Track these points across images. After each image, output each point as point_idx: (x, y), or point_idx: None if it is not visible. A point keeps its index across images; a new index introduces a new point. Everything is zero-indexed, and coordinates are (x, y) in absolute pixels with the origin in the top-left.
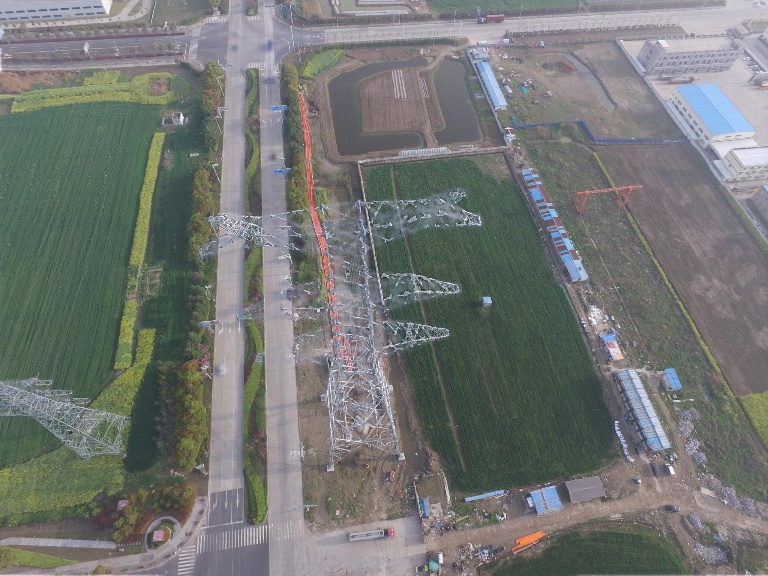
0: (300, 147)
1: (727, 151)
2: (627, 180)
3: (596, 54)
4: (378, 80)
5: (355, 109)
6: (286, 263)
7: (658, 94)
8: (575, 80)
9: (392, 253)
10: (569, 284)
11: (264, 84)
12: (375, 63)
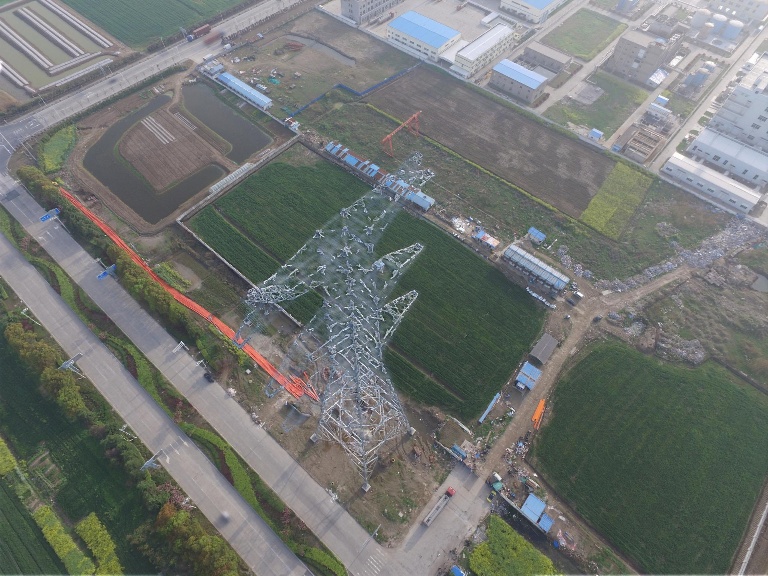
0: (105, 240)
1: (454, 56)
2: (405, 113)
3: (309, 25)
4: (134, 136)
5: (132, 175)
6: (181, 353)
7: (378, 36)
8: (309, 54)
9: None
10: (425, 214)
11: (8, 201)
12: (117, 122)
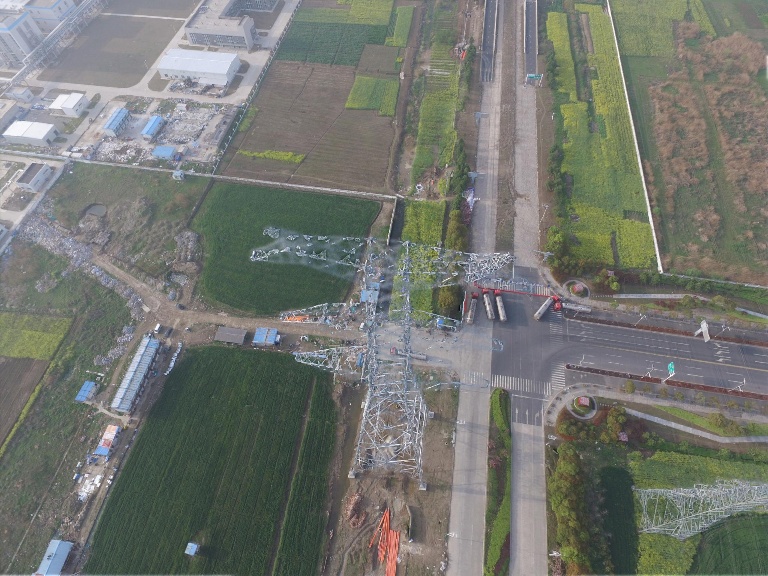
0: None
1: None
2: None
3: None
4: None
5: None
6: None
7: None
8: None
9: None
10: (80, 542)
11: None
12: None
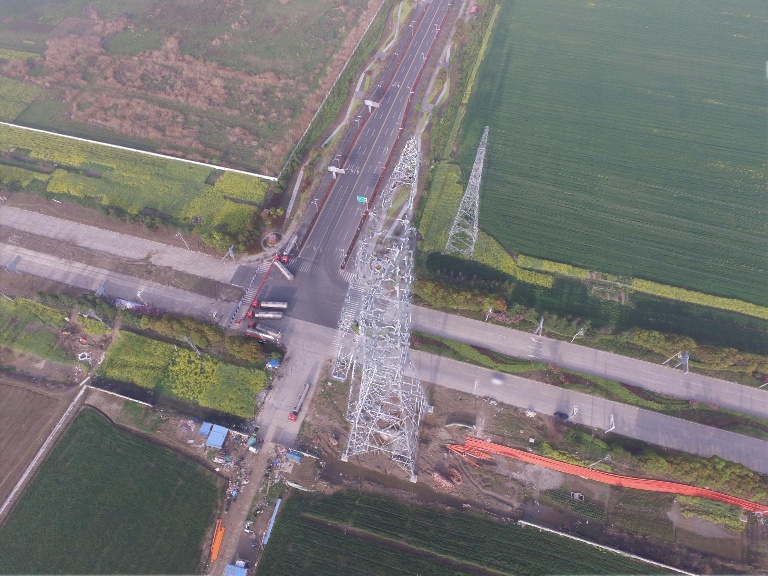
0: None
1: None
2: None
3: None
4: None
5: None
6: None
7: None
8: None
9: (599, 575)
10: None
11: None
12: None
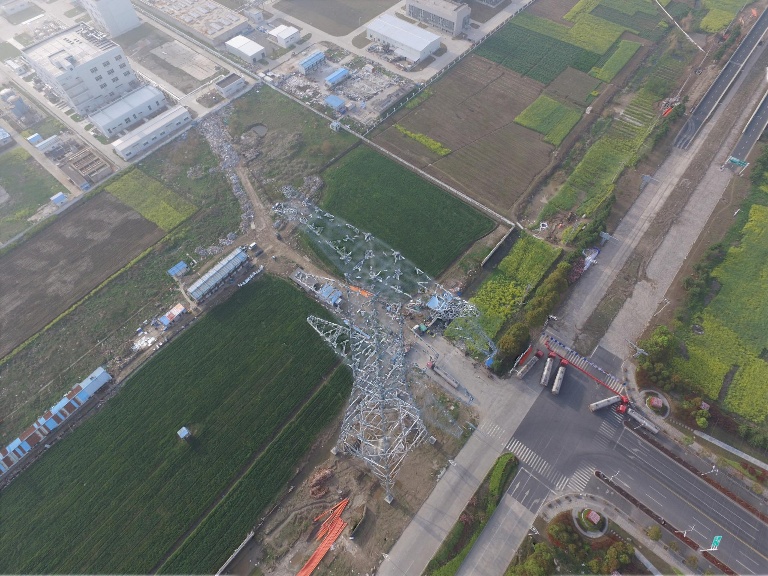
0: None
1: None
2: None
3: None
4: None
5: None
6: None
7: None
8: None
9: None
10: (116, 380)
11: None
12: None
